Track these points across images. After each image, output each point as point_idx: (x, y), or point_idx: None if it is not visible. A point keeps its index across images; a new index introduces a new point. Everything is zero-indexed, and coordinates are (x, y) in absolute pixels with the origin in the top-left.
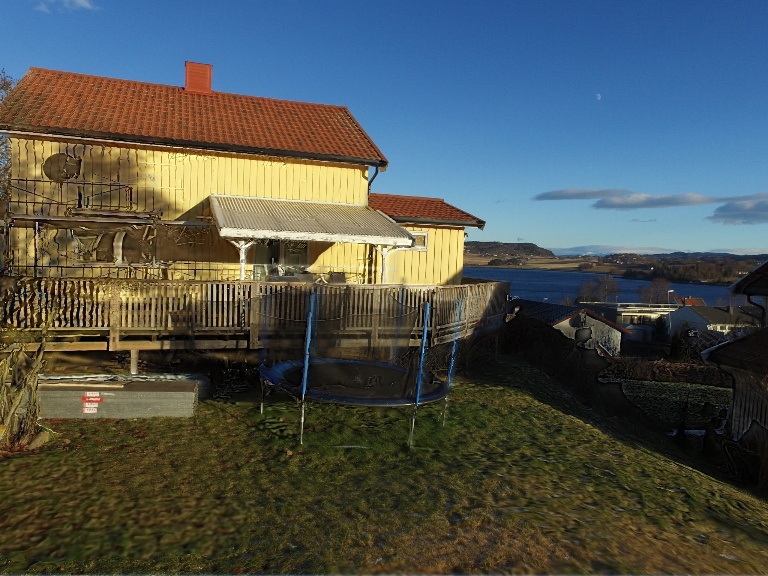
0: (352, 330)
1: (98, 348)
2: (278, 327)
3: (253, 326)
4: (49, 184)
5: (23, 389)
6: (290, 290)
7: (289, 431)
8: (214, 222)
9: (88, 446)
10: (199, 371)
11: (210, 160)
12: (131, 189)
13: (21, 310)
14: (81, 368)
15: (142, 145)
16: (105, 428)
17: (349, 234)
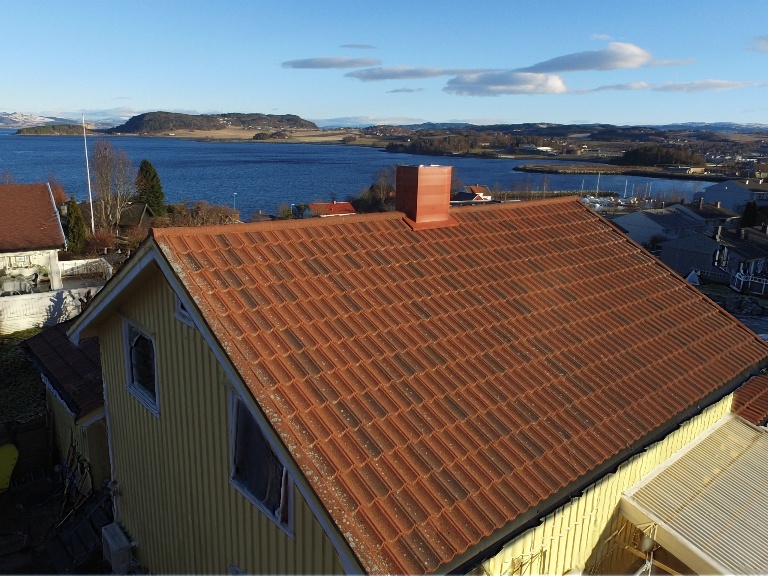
0: None
1: None
2: None
3: None
4: None
5: None
6: None
7: None
8: None
9: None
10: None
11: None
12: (544, 553)
13: None
14: None
15: None
16: None
17: None
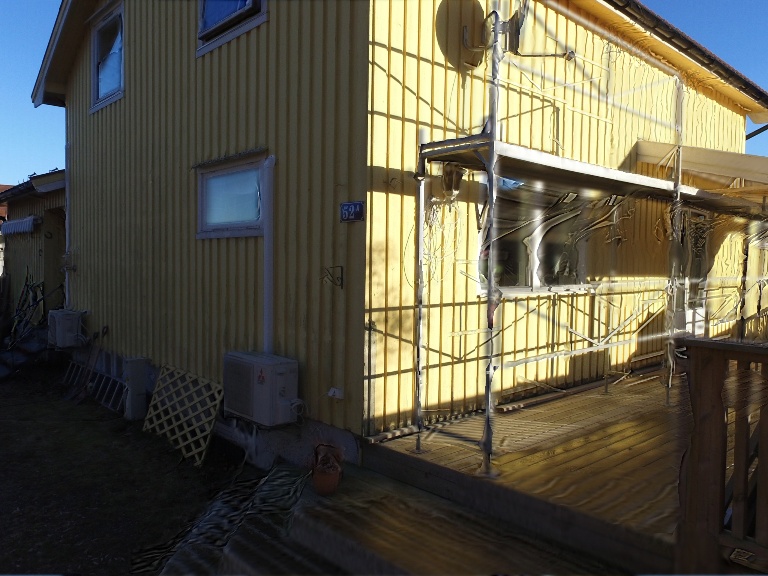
0: None
1: None
2: None
3: None
4: (442, 73)
5: None
6: None
7: None
8: (734, 192)
9: None
10: None
11: (642, 68)
12: (557, 111)
13: None
14: None
15: (576, 10)
16: None
17: None
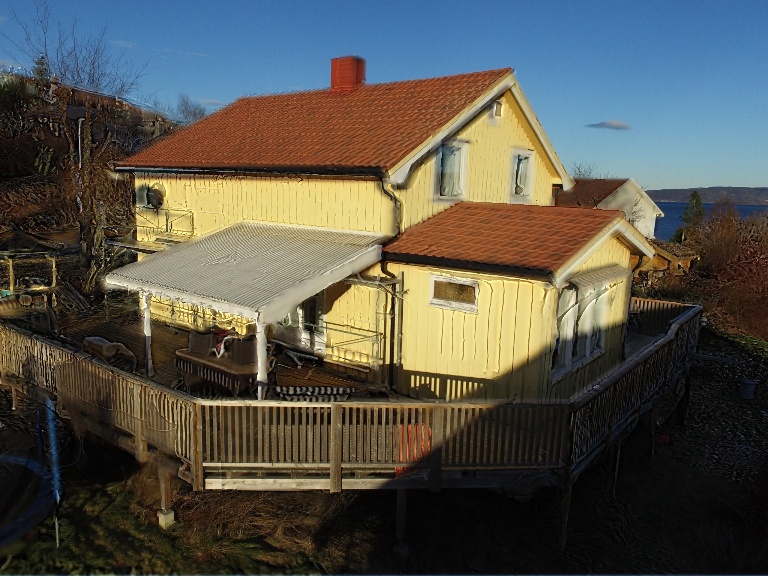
0: (124, 429)
1: None
2: (73, 401)
3: (59, 393)
4: (153, 210)
5: None
6: None
7: None
8: None
9: None
10: None
11: (240, 181)
12: (193, 214)
13: None
14: None
15: None
16: None
17: (198, 294)
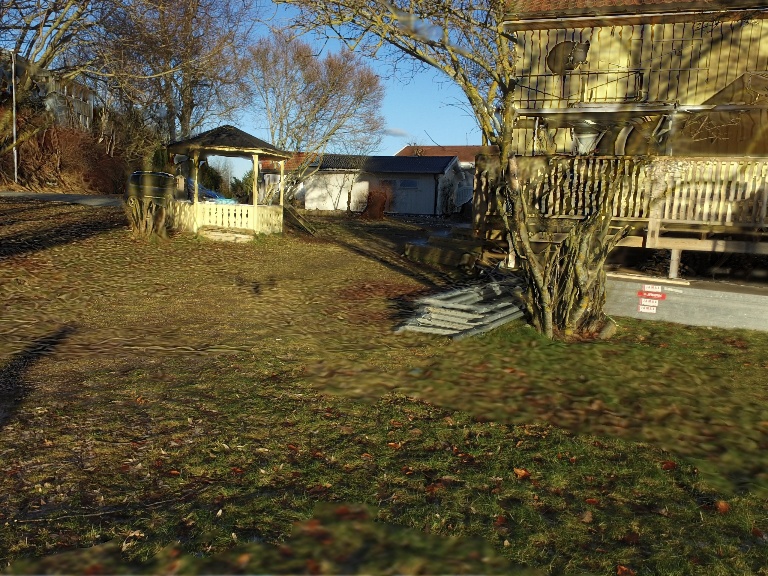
0: None
1: (631, 244)
2: None
3: None
4: (552, 78)
5: (603, 259)
6: None
7: None
8: (759, 102)
9: (673, 346)
10: None
11: (750, 25)
12: (642, 75)
13: (550, 194)
14: (612, 266)
15: (660, 18)
16: (677, 331)
17: None
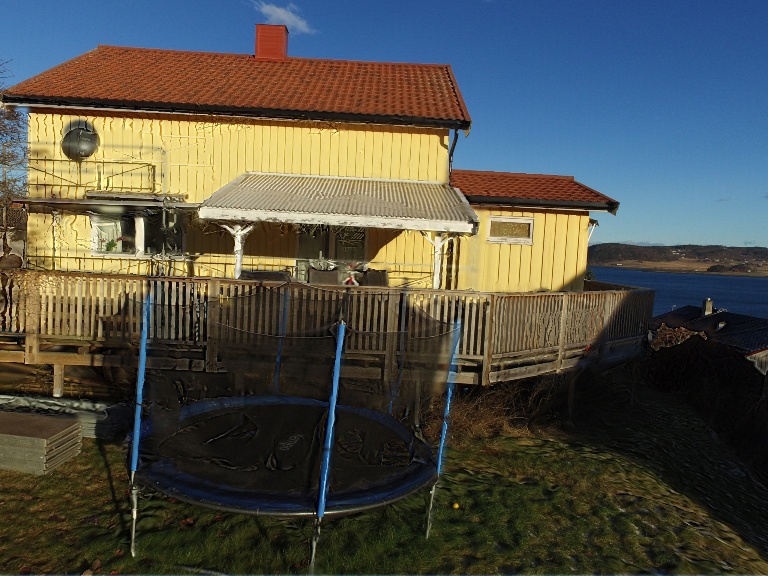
0: (356, 354)
1: (14, 359)
2: (246, 344)
3: (211, 341)
4: (68, 164)
5: None
6: (263, 292)
7: (147, 521)
8: None
9: None
10: (158, 396)
11: (244, 129)
12: (154, 167)
13: None
14: None
15: (166, 115)
16: None
17: (378, 215)
